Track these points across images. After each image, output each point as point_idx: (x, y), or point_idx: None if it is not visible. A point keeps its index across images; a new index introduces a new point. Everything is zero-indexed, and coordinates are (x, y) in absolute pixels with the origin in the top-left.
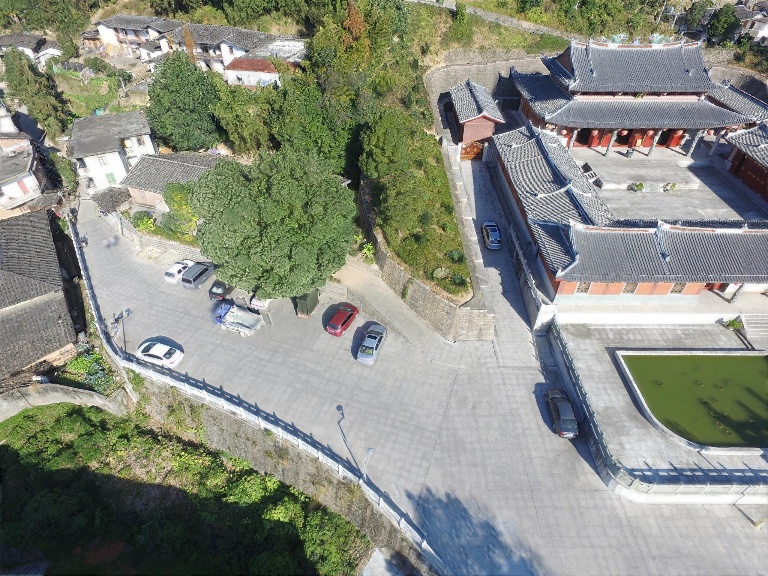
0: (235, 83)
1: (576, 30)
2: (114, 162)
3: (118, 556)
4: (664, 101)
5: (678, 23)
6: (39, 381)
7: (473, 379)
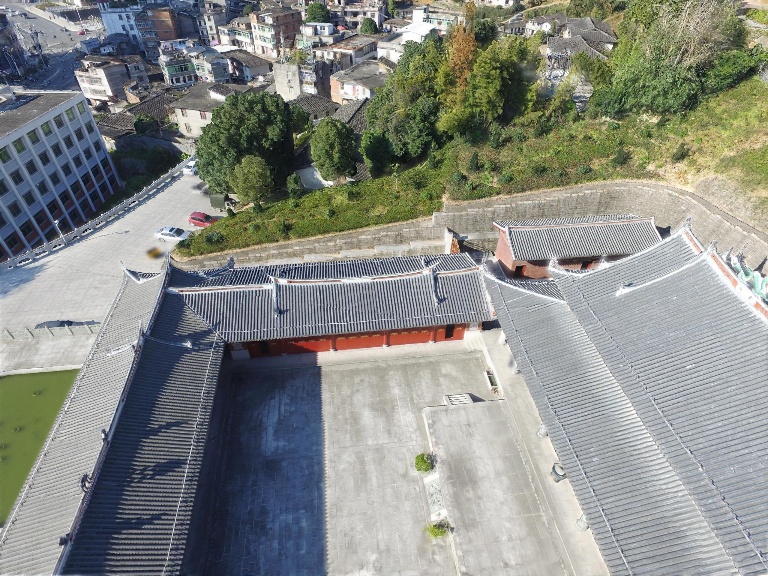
0: None
1: None
2: (367, 96)
3: None
4: None
5: None
6: None
7: None
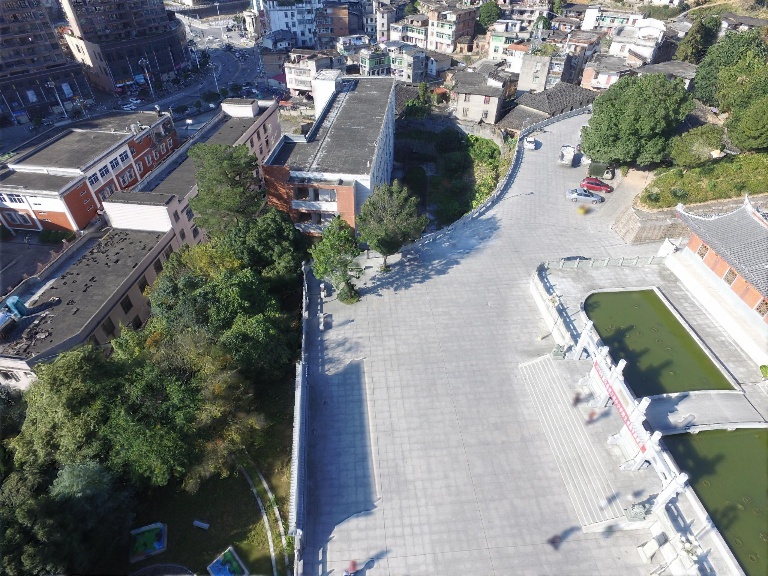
0: None
1: None
2: None
3: (447, 187)
4: None
5: None
6: (502, 132)
7: (584, 235)
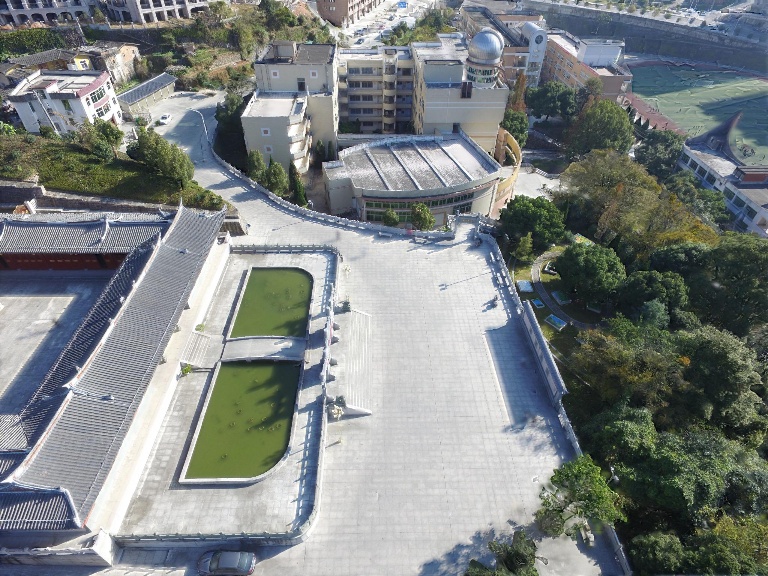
0: None
1: None
2: None
3: None
4: None
5: None
6: None
7: None
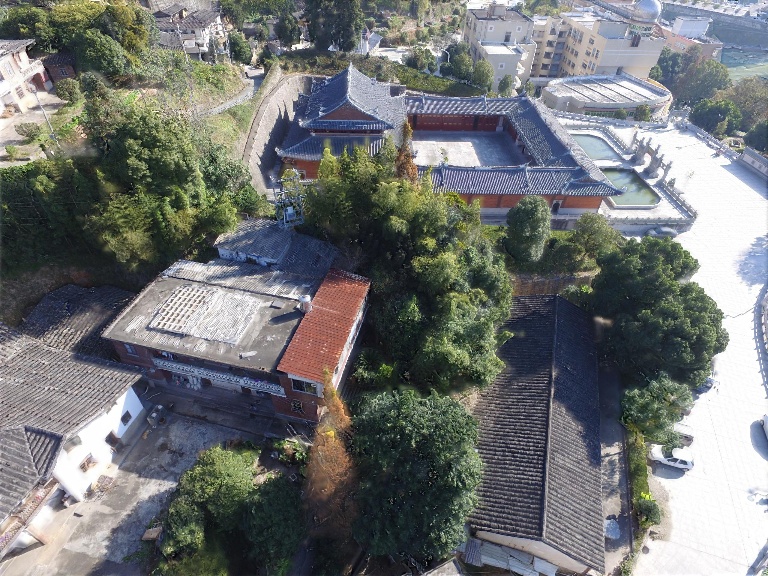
0: (334, 385)
1: (216, 95)
2: None
3: None
4: None
5: (206, 59)
6: None
7: None
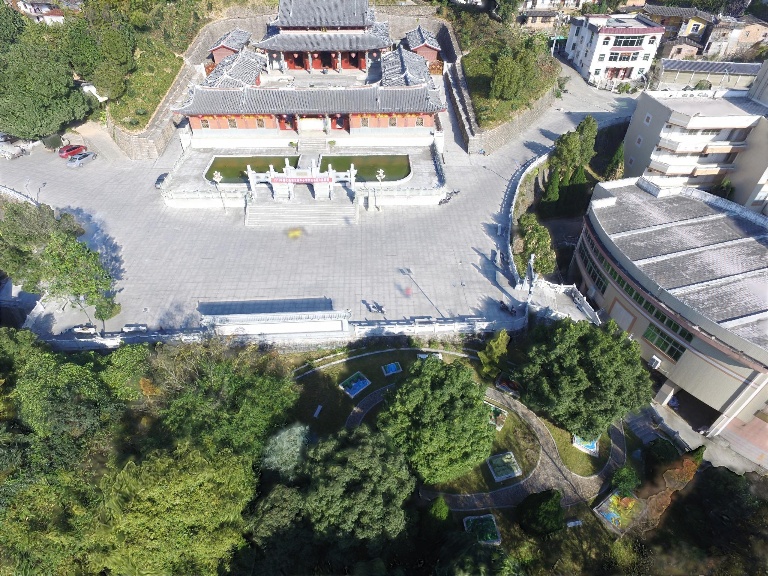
0: None
1: None
2: None
3: None
4: (342, 34)
5: None
6: None
7: (131, 173)
